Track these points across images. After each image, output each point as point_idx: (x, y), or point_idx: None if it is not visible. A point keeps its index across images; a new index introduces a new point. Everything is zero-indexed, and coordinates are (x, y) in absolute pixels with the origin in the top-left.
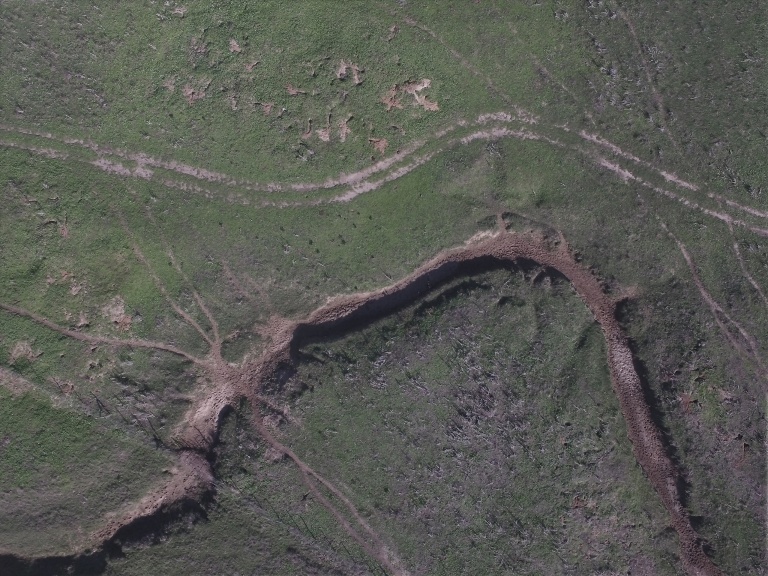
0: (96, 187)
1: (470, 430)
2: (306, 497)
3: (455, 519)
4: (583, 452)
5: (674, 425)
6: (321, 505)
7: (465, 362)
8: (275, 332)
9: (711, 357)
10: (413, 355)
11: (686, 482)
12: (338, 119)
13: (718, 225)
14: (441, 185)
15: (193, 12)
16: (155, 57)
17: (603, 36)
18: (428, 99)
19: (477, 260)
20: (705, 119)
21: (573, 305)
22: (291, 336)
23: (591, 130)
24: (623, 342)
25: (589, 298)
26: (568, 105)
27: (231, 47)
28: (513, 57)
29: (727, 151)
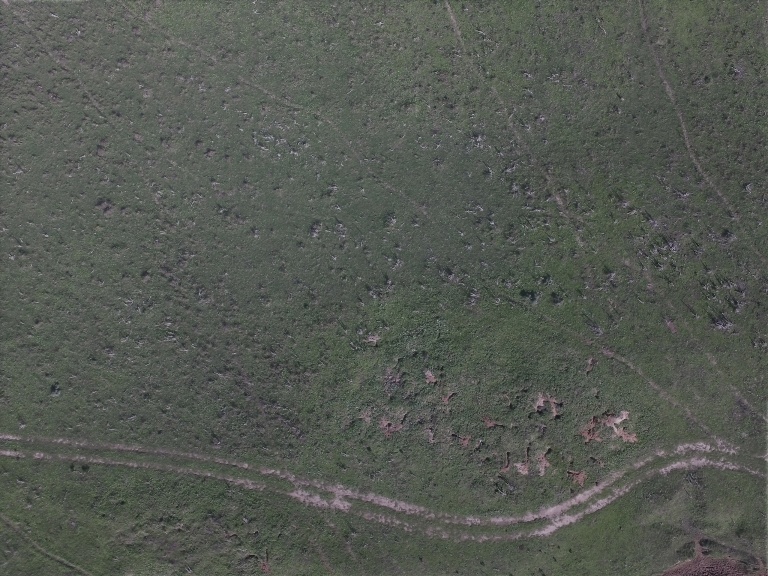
0: (295, 521)
1: None
2: None
3: None
4: None
5: None
6: None
7: None
8: None
9: None
10: None
11: None
12: (537, 453)
13: None
14: (641, 517)
15: (386, 340)
16: (351, 388)
17: None
18: (626, 430)
19: None
20: None
21: None
22: None
23: None
24: None
25: None
26: None
27: (427, 379)
28: (713, 389)
29: None
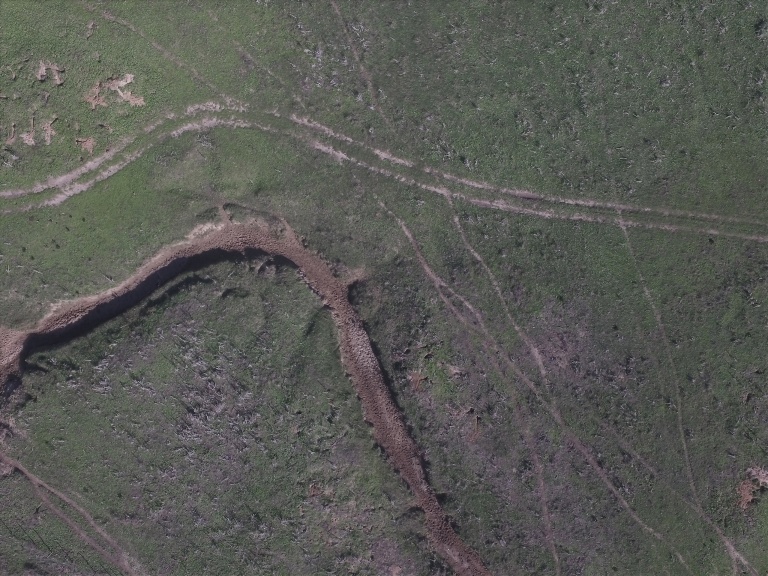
0: None
1: (201, 427)
2: (38, 510)
3: (193, 518)
4: (316, 439)
5: (408, 404)
6: (54, 516)
7: (189, 359)
8: (3, 344)
9: (437, 333)
10: (136, 356)
11: (425, 460)
12: (41, 122)
13: (436, 200)
14: (154, 181)
15: None
16: None
17: (306, 18)
18: (133, 95)
19: (205, 254)
20: (415, 94)
21: (297, 292)
22: (20, 347)
23: (301, 114)
24: (359, 325)
25: (320, 283)
26: (276, 90)
27: None
28: (216, 46)
29: (440, 125)
